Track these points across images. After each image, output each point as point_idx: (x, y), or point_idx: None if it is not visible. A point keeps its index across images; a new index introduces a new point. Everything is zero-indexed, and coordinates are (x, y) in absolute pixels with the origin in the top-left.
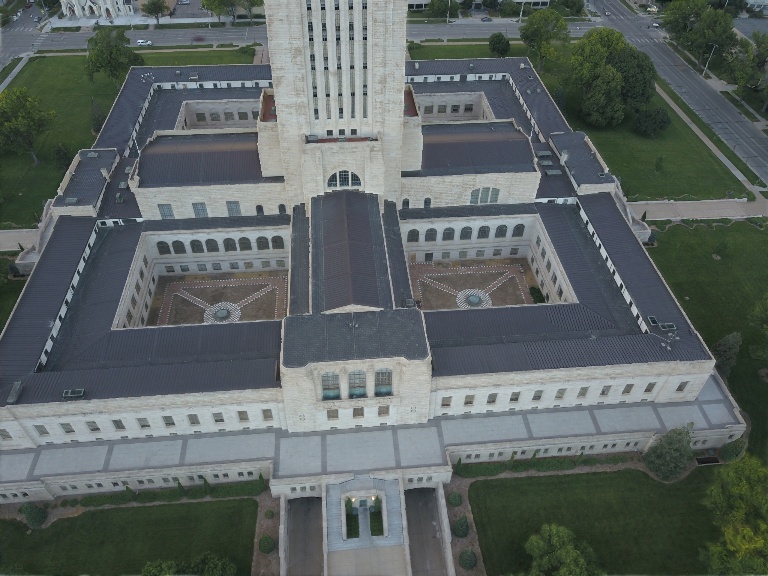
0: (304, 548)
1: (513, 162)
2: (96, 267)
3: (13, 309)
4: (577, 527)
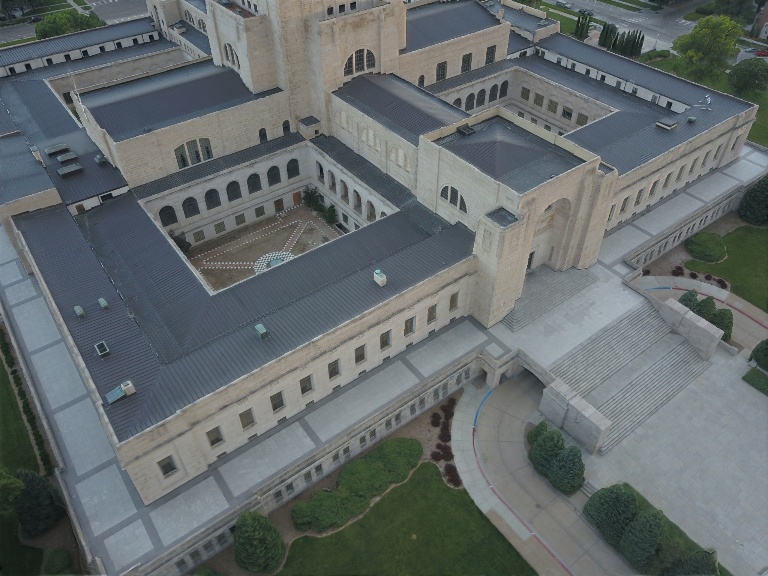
0: None
1: (108, 96)
2: None
3: None
4: None
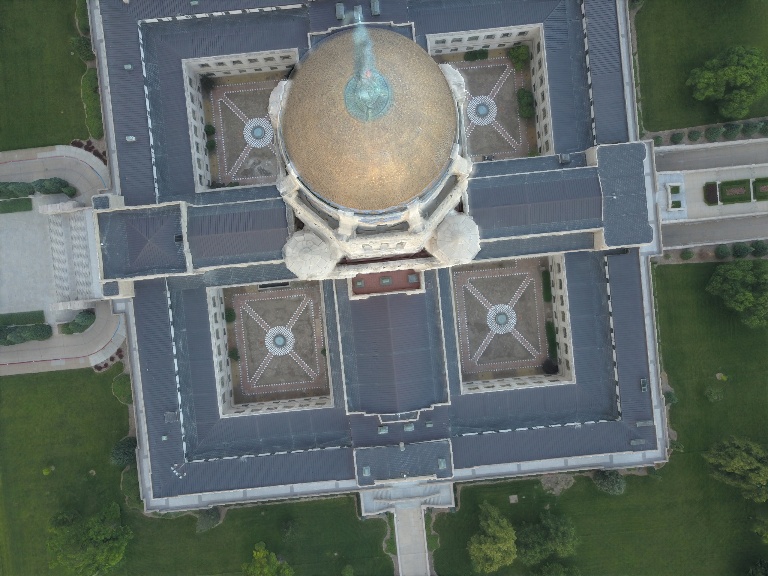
0: (670, 237)
1: None
2: (501, 421)
3: None
4: (673, 66)
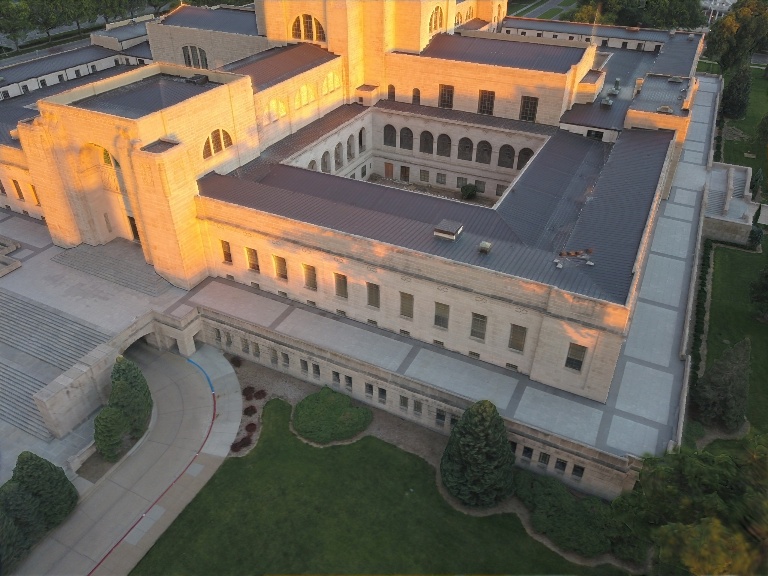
0: None
1: None
2: None
3: (697, 53)
4: None
